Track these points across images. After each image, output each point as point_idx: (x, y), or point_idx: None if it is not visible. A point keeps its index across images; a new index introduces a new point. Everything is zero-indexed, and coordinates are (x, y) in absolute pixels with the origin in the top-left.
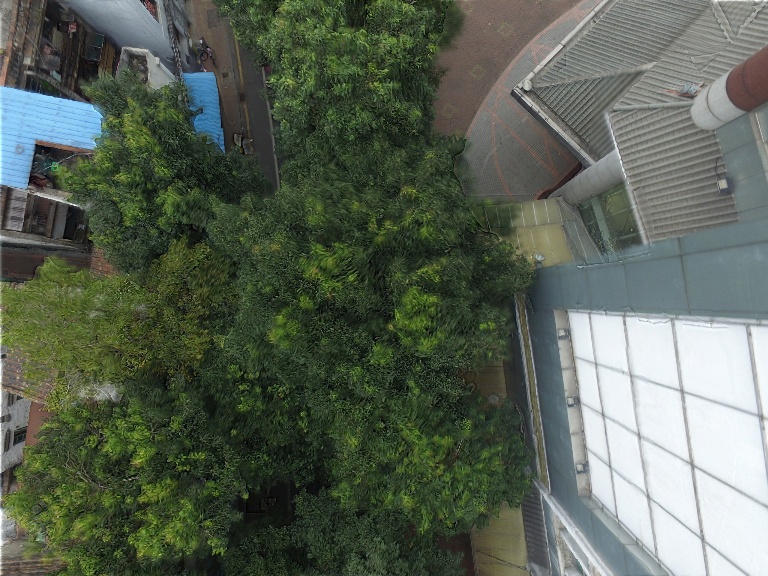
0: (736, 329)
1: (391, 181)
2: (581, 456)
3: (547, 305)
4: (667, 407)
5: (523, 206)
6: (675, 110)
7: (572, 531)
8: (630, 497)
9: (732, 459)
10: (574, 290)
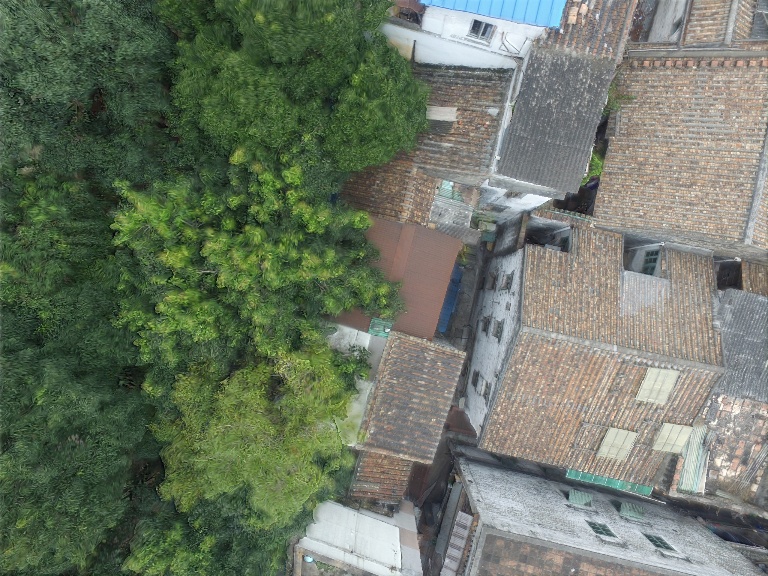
0: None
1: None
2: None
3: None
4: None
5: None
6: None
7: None
8: None
9: None
10: None
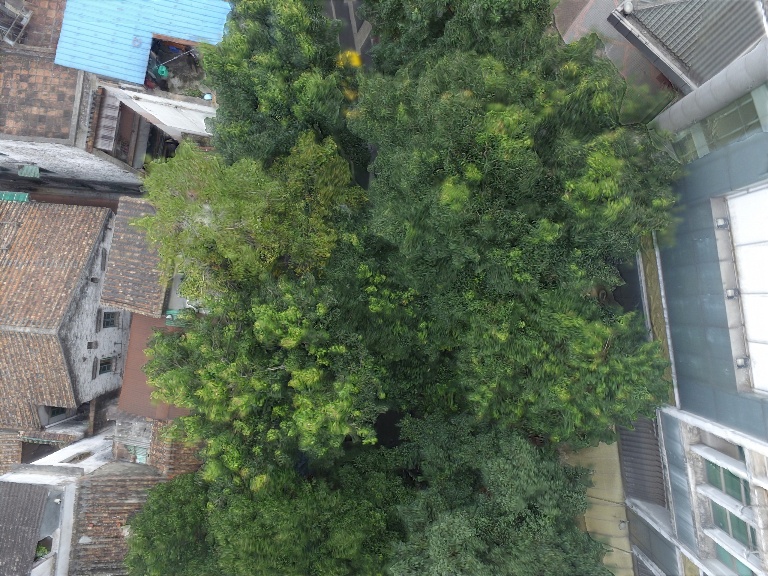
0: None
1: (548, 58)
2: (740, 351)
3: (698, 198)
4: None
5: None
6: None
7: (726, 433)
8: None
9: None
10: (758, 160)
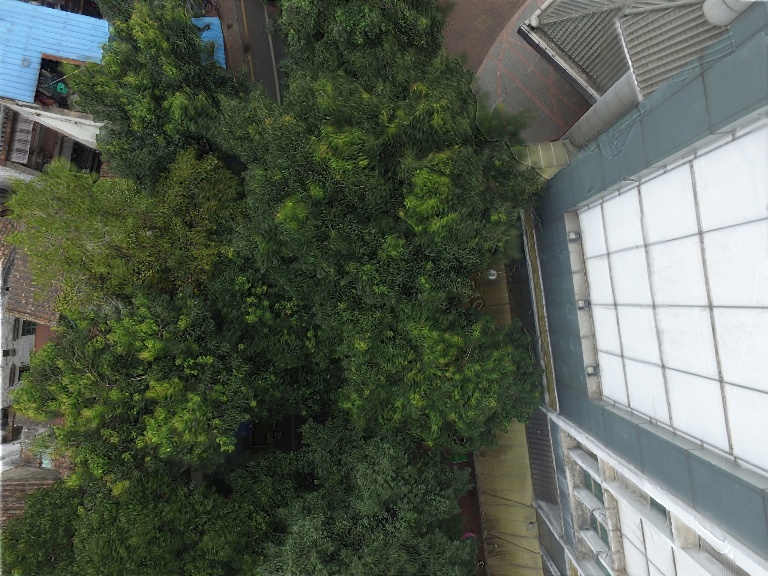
0: (760, 126)
1: (401, 79)
2: (591, 359)
3: (557, 212)
4: (684, 259)
5: (529, 149)
6: (687, 8)
7: (582, 438)
8: (643, 378)
9: (754, 276)
10: (586, 178)
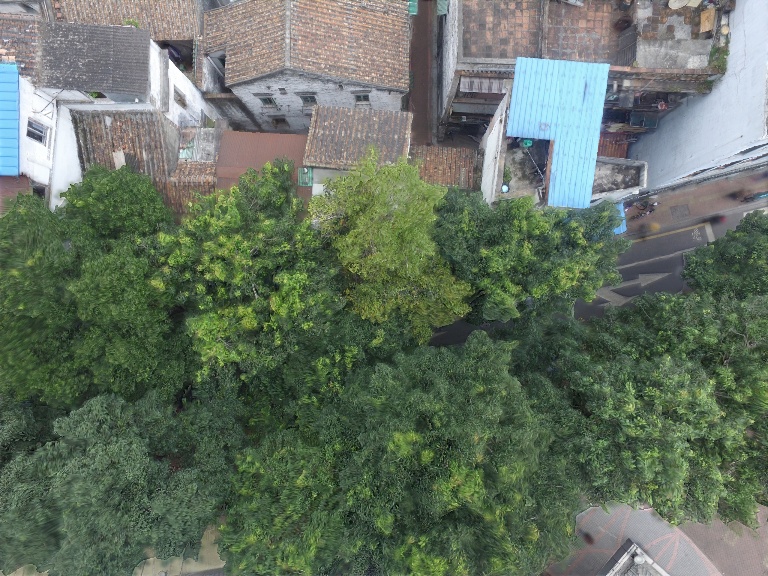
0: None
1: (545, 511)
2: None
3: None
4: None
5: None
6: None
7: None
8: None
9: None
10: None
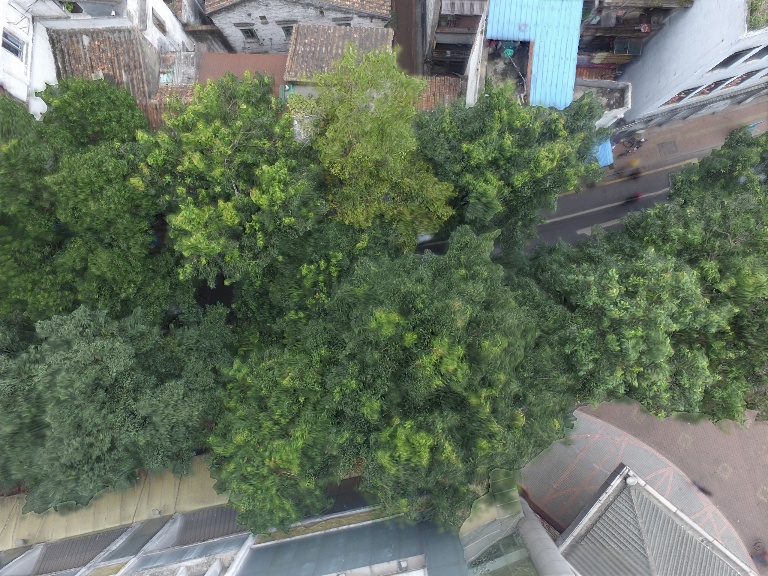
0: None
1: (531, 398)
2: None
3: (427, 545)
4: None
5: (511, 479)
6: None
7: None
8: None
9: None
10: None
